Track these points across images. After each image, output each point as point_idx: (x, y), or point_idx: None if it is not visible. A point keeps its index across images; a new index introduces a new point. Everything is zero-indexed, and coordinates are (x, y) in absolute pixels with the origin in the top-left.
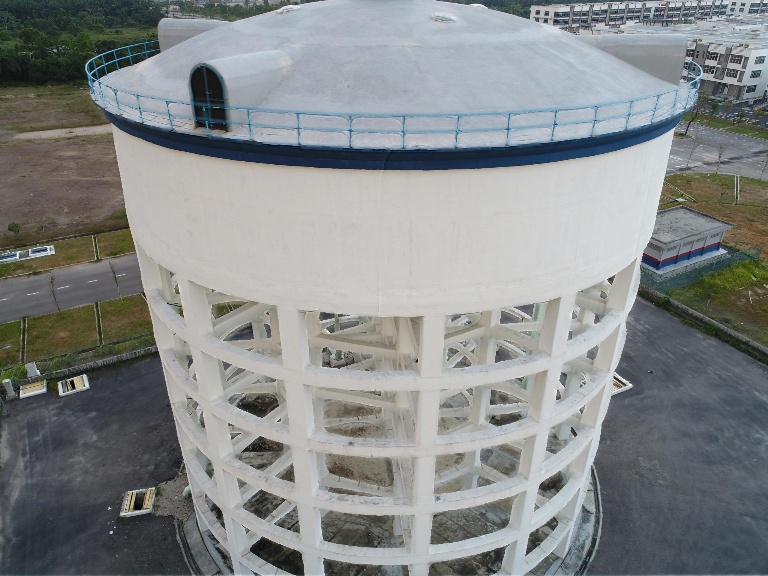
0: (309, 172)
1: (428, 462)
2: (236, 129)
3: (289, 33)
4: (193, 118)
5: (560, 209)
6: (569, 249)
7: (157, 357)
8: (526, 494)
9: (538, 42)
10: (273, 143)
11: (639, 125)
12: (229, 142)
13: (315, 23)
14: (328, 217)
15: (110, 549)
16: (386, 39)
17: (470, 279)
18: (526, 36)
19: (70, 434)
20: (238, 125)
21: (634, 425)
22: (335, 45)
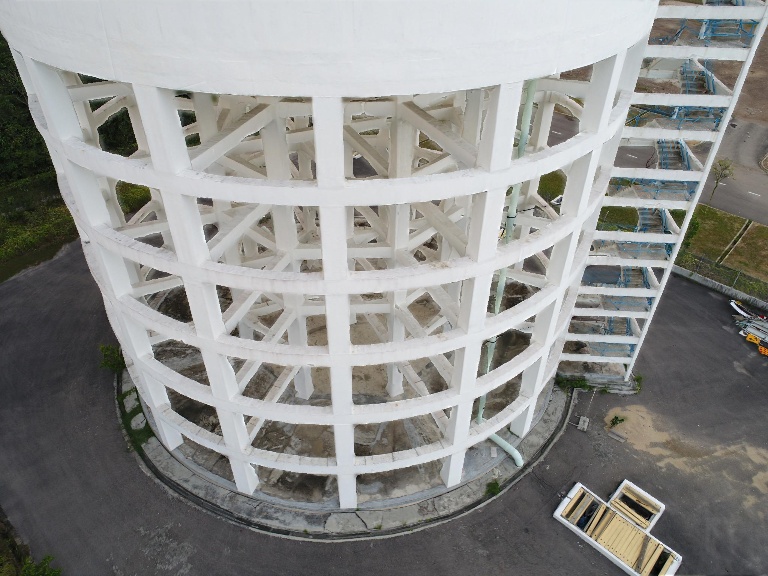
0: None
1: None
2: None
3: None
4: None
5: None
6: None
7: None
8: (113, 307)
9: None
10: None
11: None
12: None
13: None
14: None
15: None
16: None
17: None
18: None
19: None
20: None
21: None
22: None
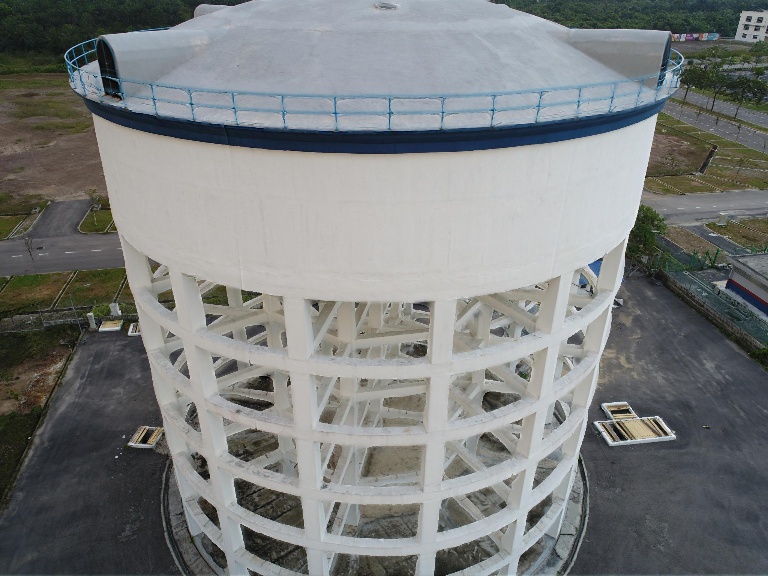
0: (174, 142)
1: (307, 446)
2: (128, 98)
3: (237, 16)
4: (103, 86)
5: (421, 206)
6: (438, 250)
7: (217, 317)
8: (423, 507)
9: (476, 33)
10: (138, 111)
11: (515, 123)
12: (112, 108)
13: (266, 7)
14: (193, 187)
15: (110, 470)
16: (306, 23)
17: (324, 266)
18: (467, 26)
19: (122, 368)
20: (131, 95)
21: (658, 480)
22: (258, 27)
